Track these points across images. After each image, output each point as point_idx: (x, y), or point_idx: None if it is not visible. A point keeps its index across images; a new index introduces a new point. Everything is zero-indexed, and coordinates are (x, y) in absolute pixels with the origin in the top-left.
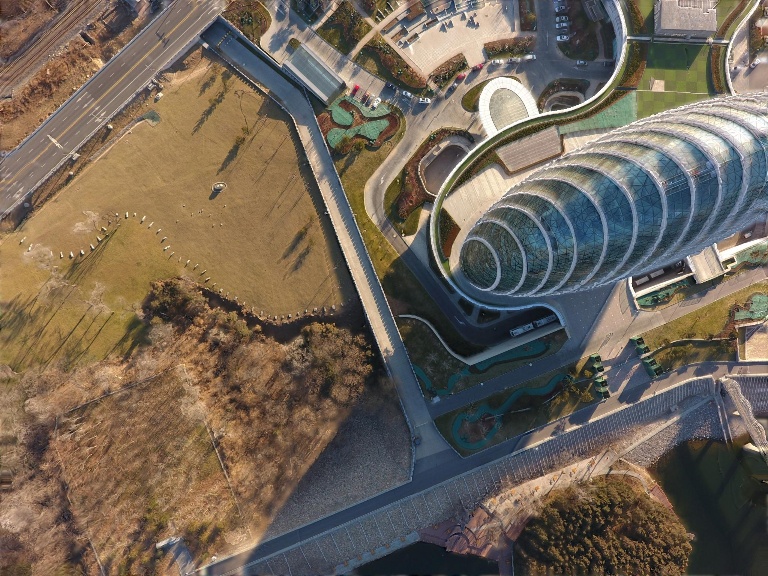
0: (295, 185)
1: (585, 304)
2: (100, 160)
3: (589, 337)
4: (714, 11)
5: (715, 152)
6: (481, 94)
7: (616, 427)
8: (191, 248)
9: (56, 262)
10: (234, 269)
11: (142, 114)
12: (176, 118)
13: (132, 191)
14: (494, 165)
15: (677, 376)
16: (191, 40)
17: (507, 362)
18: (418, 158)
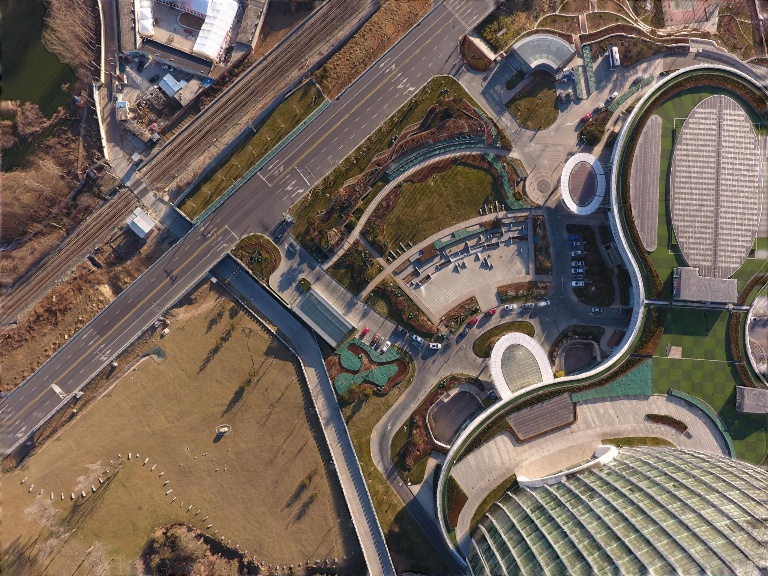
0: (301, 430)
1: None
2: (104, 397)
3: None
4: (735, 281)
5: None
6: (493, 350)
7: None
8: (193, 493)
9: (57, 504)
10: (236, 516)
11: (148, 350)
12: (182, 356)
13: (135, 431)
14: (504, 432)
15: None
16: (199, 278)
17: None
18: (427, 406)
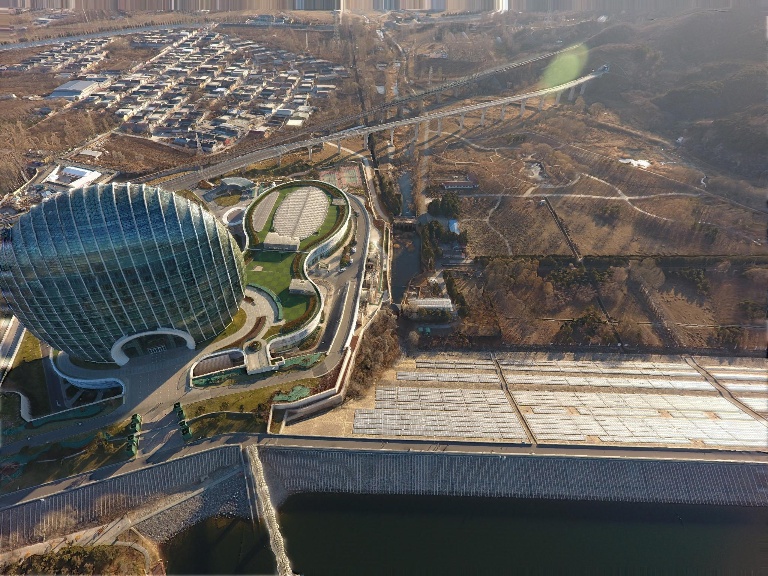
0: None
1: (150, 381)
2: None
3: (141, 405)
4: (298, 238)
5: None
6: None
7: (138, 491)
8: None
9: None
10: None
11: None
12: None
13: None
14: None
15: (209, 443)
16: None
17: (61, 421)
18: None
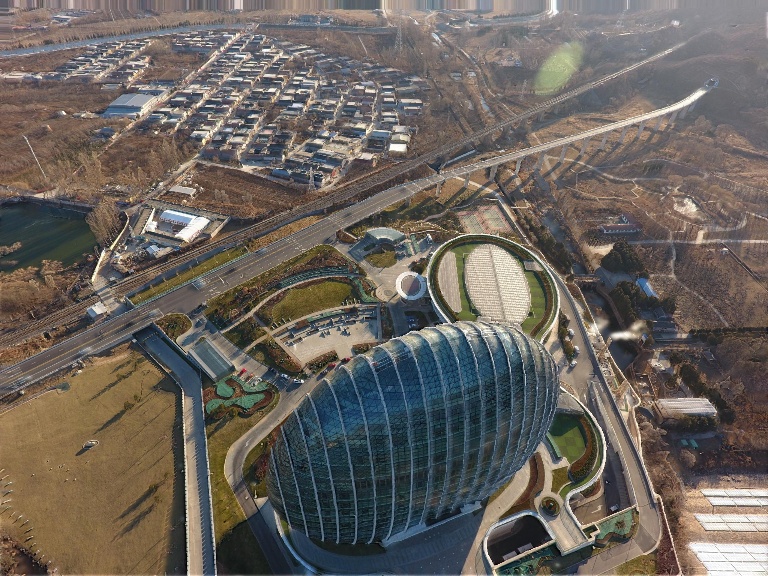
0: (163, 445)
1: (437, 575)
2: None
3: None
4: (519, 325)
5: (412, 342)
6: None
7: None
8: (31, 503)
9: None
10: (64, 527)
11: (56, 385)
12: (83, 388)
13: (7, 446)
14: None
15: None
16: (124, 336)
17: None
18: None
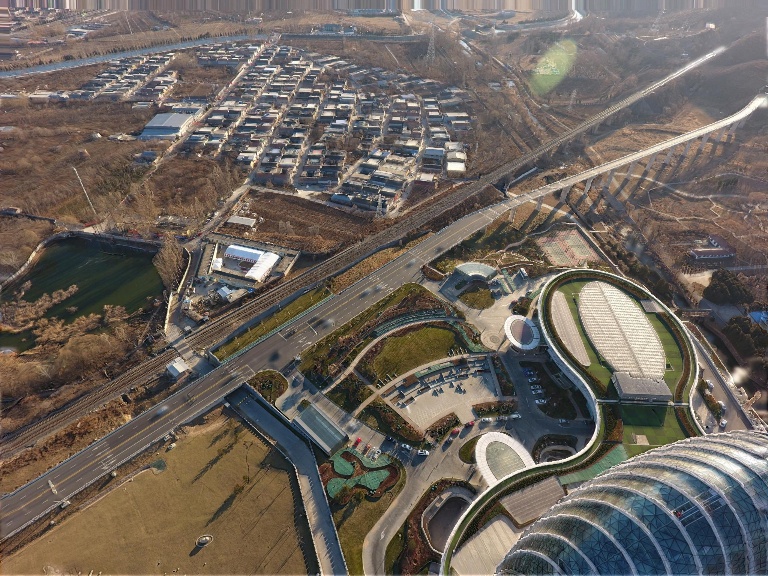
0: (288, 539)
1: None
2: (89, 508)
3: None
4: (663, 381)
5: (712, 479)
6: (476, 446)
7: None
8: None
9: None
10: None
11: (150, 463)
12: (181, 467)
13: (108, 544)
14: (501, 517)
15: None
16: (216, 400)
17: None
18: (420, 510)
